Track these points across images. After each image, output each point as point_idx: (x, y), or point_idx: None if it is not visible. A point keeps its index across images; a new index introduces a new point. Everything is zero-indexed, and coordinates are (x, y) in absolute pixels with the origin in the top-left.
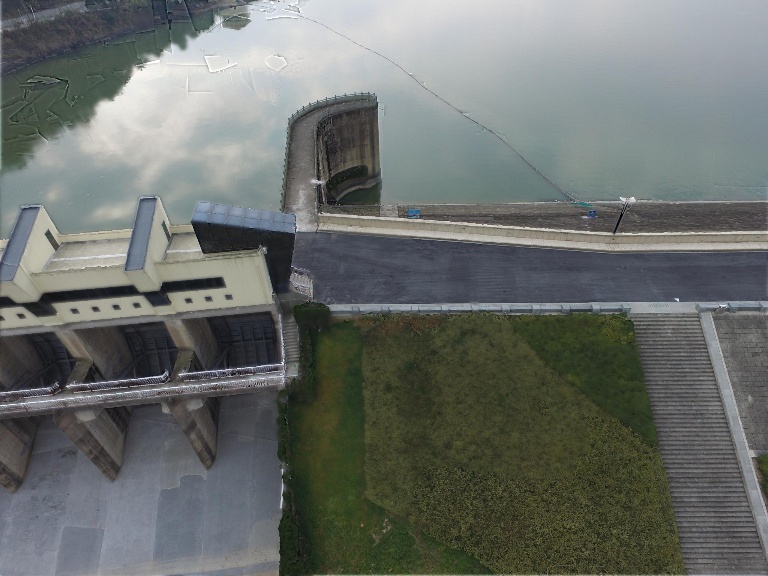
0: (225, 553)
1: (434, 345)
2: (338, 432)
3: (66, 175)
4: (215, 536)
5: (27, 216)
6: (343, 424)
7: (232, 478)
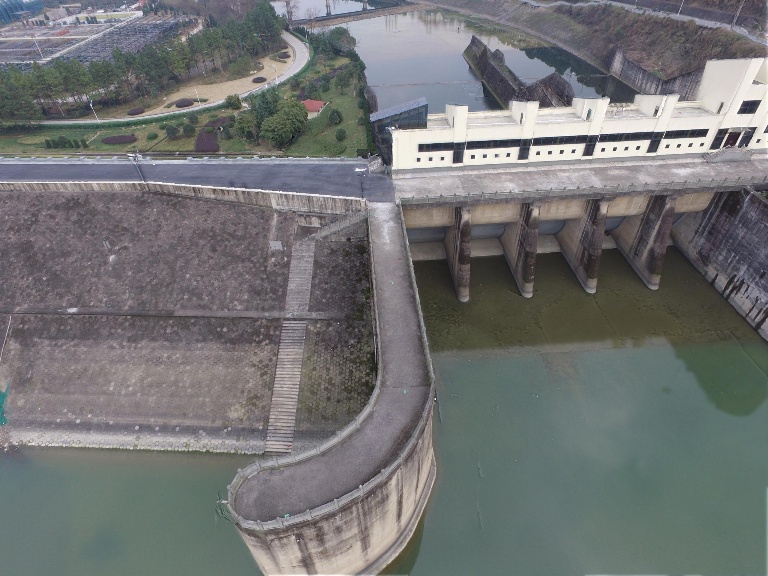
0: None
1: None
2: None
3: None
4: None
5: None
6: None
7: None
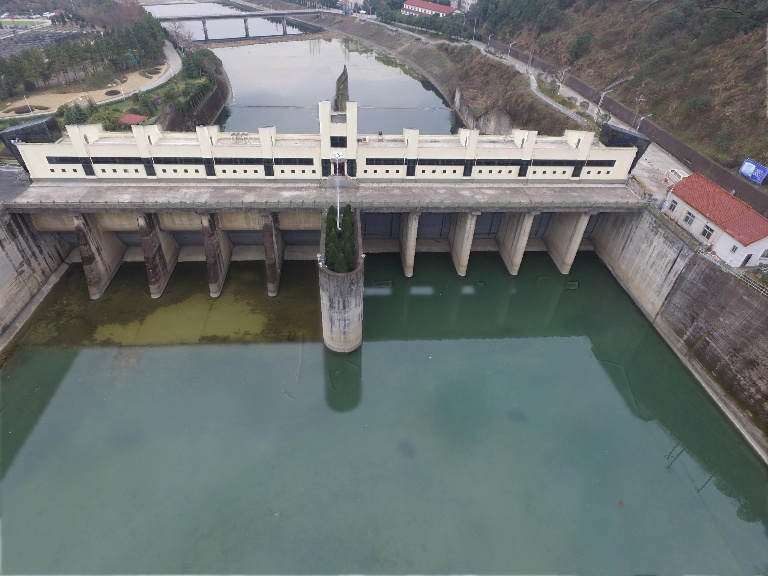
0: None
1: None
2: None
3: None
4: None
5: None
6: None
7: None
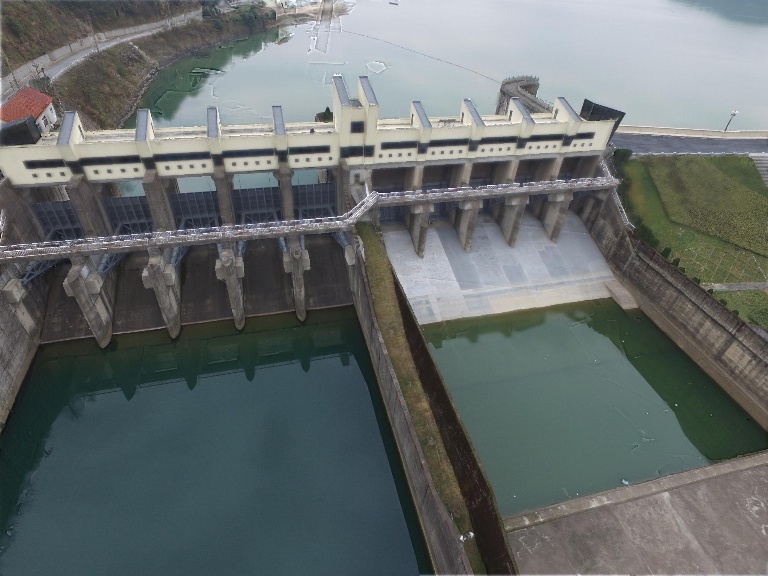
0: (582, 273)
1: (678, 166)
2: (646, 201)
3: None
4: (574, 268)
5: None
6: (648, 198)
7: (569, 247)
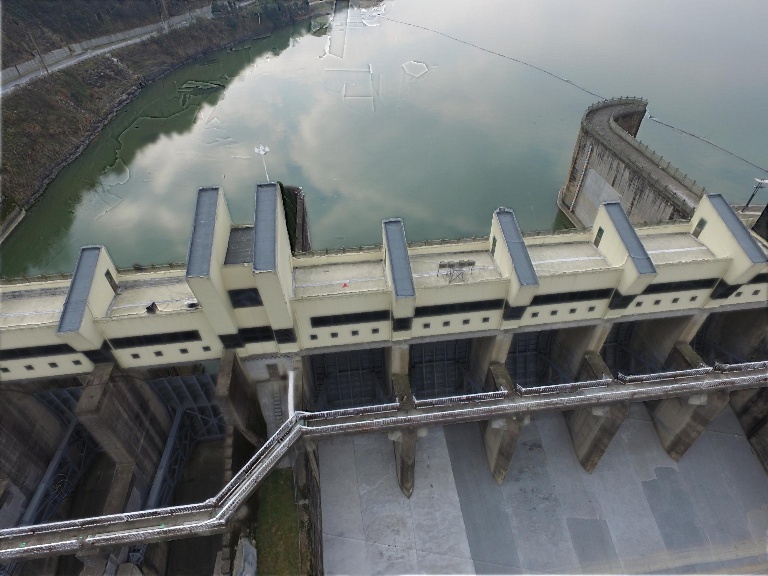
0: (733, 543)
1: None
2: None
3: (298, 177)
4: (715, 526)
5: (612, 211)
6: None
7: (704, 470)
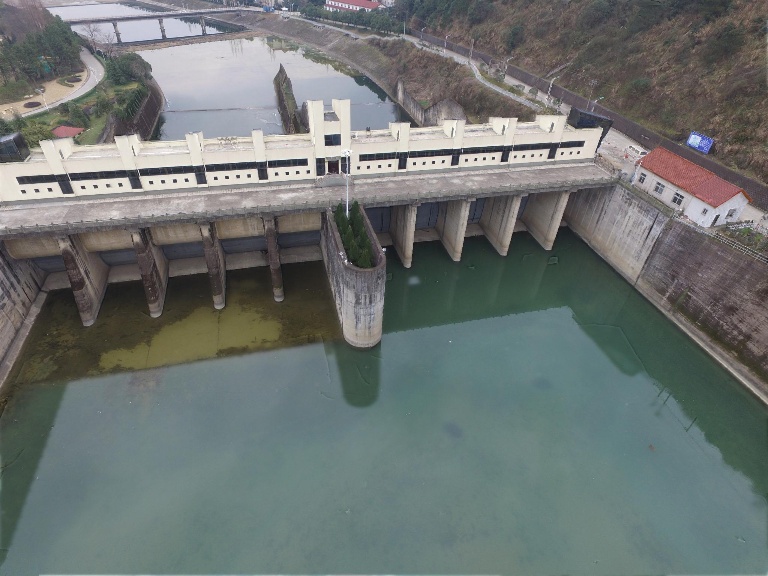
0: None
1: None
2: None
3: None
4: None
5: None
6: None
7: None
